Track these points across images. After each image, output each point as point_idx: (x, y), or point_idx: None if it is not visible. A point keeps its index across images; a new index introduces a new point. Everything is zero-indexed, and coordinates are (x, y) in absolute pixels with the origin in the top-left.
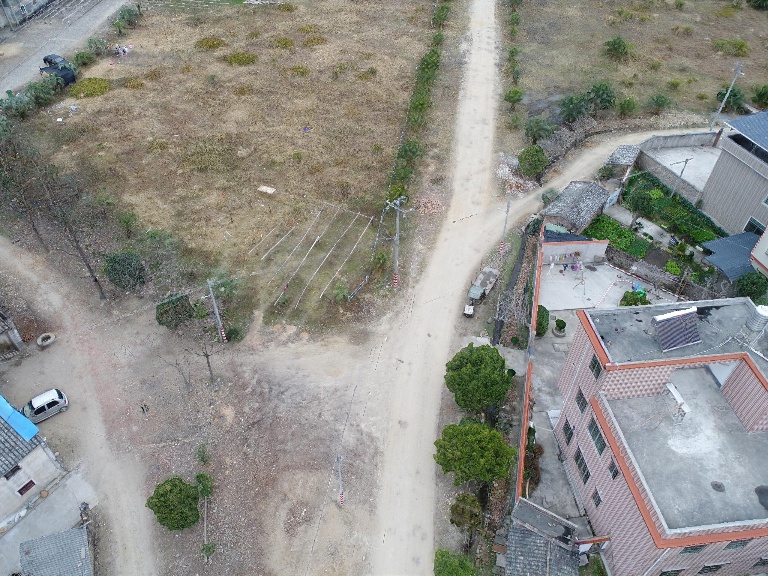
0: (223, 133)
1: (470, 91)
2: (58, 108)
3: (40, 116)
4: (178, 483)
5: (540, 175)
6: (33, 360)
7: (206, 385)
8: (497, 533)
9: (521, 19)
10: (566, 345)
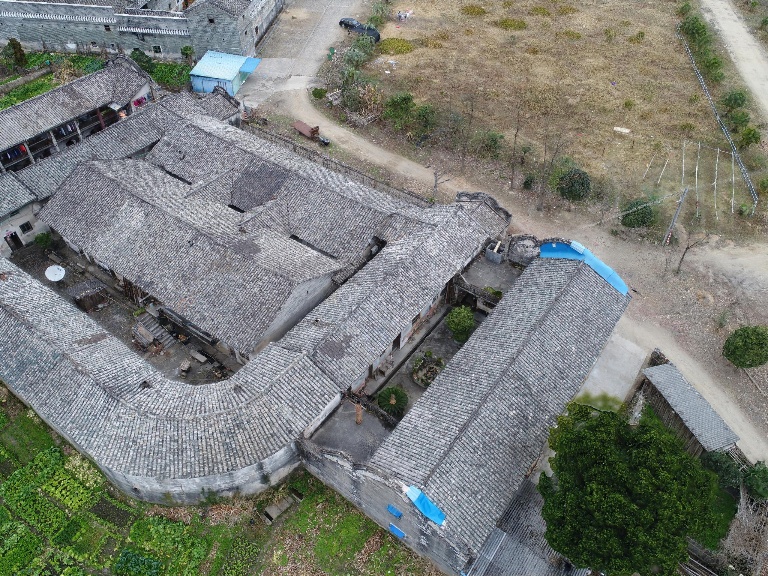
0: (541, 85)
1: (740, 54)
2: (379, 63)
3: (368, 69)
4: None
5: None
6: None
7: (672, 276)
8: None
9: None
10: None
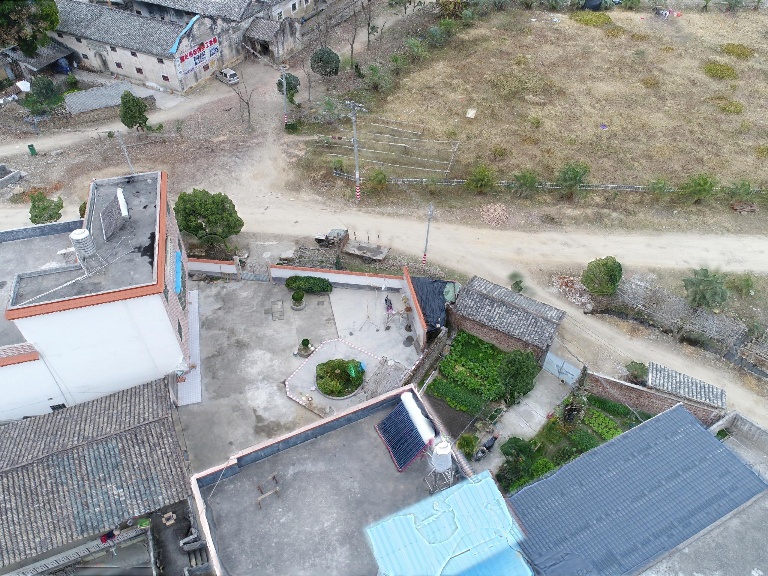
0: (563, 86)
1: None
2: (550, 15)
3: (534, 12)
4: (131, 97)
5: (619, 315)
6: (269, 69)
7: None
8: None
9: None
10: (280, 310)
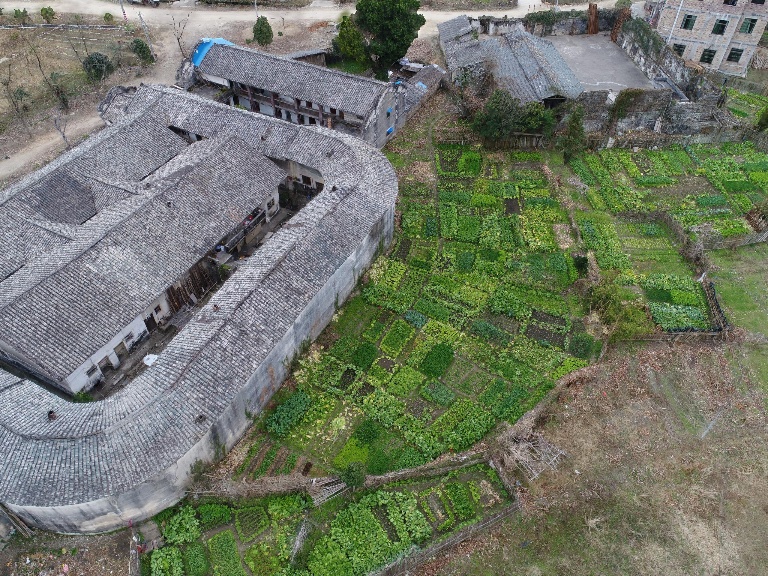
0: None
1: None
2: None
3: None
4: (259, 17)
5: None
6: None
7: None
8: (272, 1)
9: None
10: None
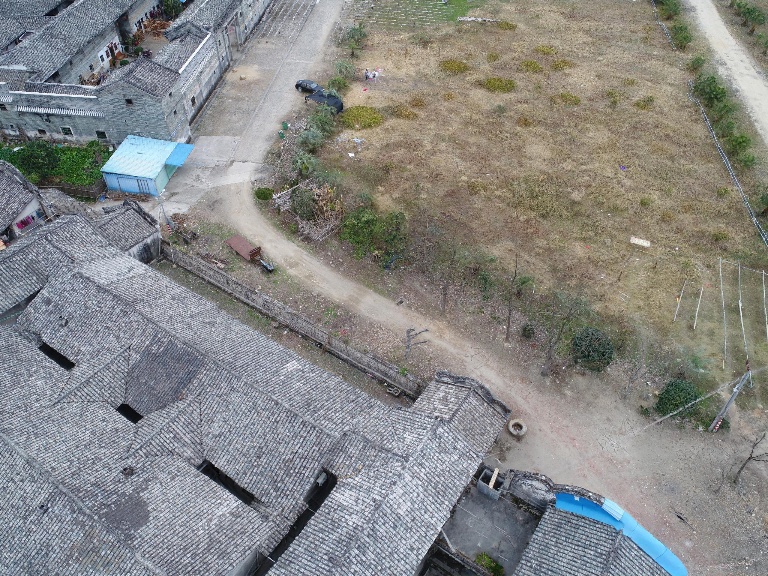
0: (537, 172)
1: (766, 124)
2: (342, 141)
3: (328, 151)
4: None
5: None
6: (517, 454)
7: (728, 487)
8: None
9: (762, 40)
10: None
